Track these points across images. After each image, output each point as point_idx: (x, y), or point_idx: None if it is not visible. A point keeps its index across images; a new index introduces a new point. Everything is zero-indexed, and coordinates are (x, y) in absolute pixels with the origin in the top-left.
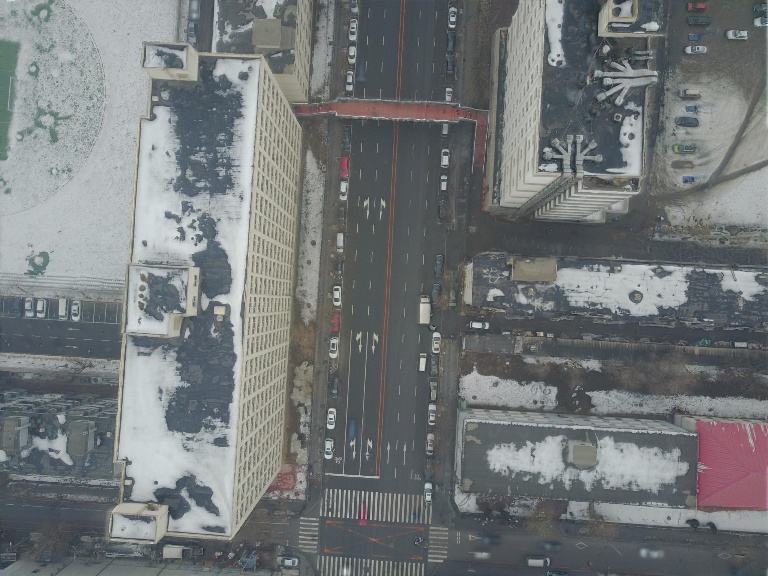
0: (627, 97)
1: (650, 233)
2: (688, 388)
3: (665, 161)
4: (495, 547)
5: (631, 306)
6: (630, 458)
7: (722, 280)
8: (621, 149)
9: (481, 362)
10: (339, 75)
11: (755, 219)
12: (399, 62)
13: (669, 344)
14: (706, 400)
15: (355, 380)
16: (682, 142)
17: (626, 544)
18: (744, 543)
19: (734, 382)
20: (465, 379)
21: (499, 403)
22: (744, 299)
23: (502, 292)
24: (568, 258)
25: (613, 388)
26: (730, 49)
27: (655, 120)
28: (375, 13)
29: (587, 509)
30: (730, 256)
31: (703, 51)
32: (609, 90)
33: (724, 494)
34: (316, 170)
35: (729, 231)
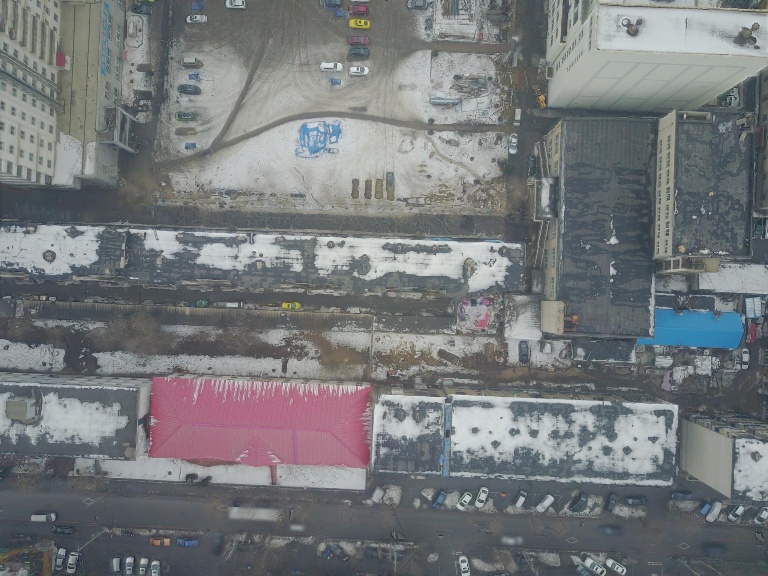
0: None
1: (153, 198)
2: (188, 348)
3: (169, 128)
4: (7, 504)
5: (45, 265)
6: (72, 413)
7: (145, 239)
8: None
9: None
10: None
11: (253, 183)
12: None
13: (169, 305)
14: (205, 359)
15: None
16: (185, 109)
17: (132, 499)
18: (241, 495)
19: None
20: None
21: (10, 365)
22: (165, 257)
23: None
24: None
25: (118, 349)
26: (231, 18)
27: (160, 88)
28: None
29: (93, 466)
30: (230, 220)
31: (201, 20)
32: None
33: (171, 446)
34: None
35: (229, 195)
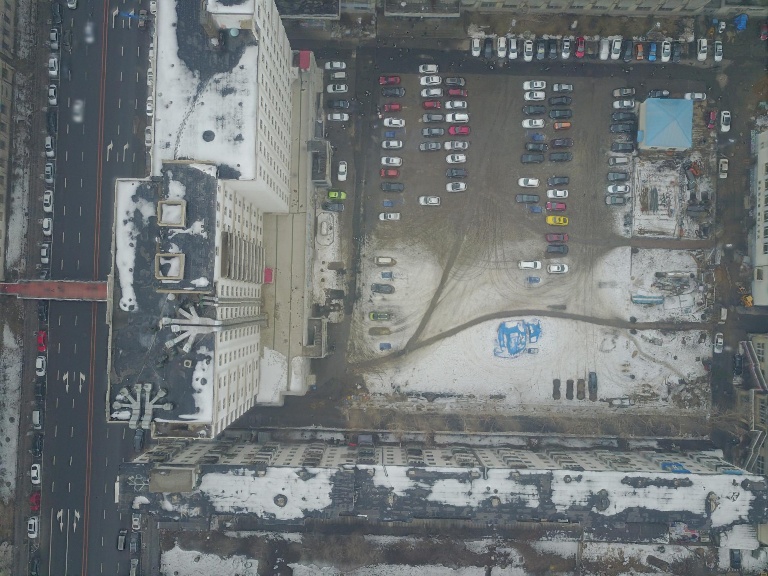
0: (199, 341)
1: (348, 402)
2: (388, 557)
3: (362, 328)
4: None
5: (276, 510)
6: None
7: (374, 476)
8: (194, 394)
9: (182, 537)
10: (35, 247)
11: (451, 385)
12: (97, 232)
13: None
14: (406, 568)
15: (57, 559)
16: (379, 309)
17: None
18: None
19: (433, 549)
20: (166, 555)
21: None
22: (395, 494)
23: (147, 499)
24: (262, 432)
25: None
26: (424, 214)
27: (352, 287)
28: (72, 182)
29: None
30: (427, 422)
31: (396, 218)
32: (177, 337)
33: None
34: (13, 345)
35: (426, 397)
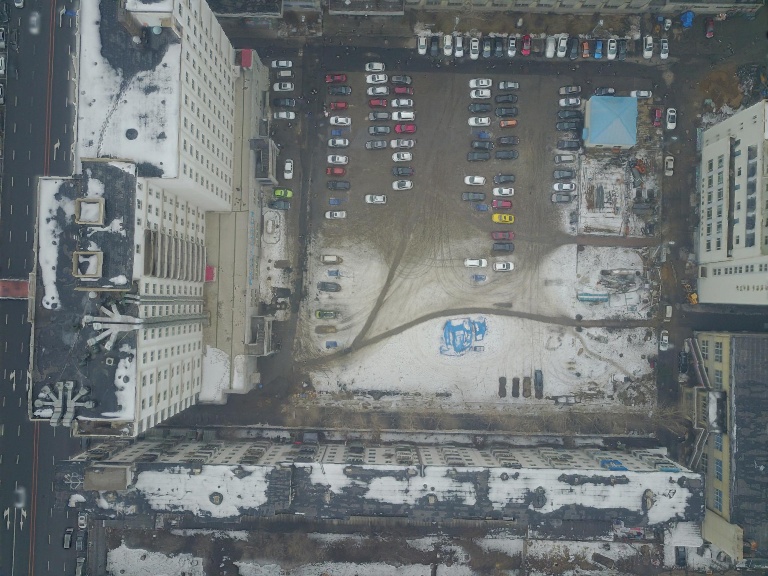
0: (122, 339)
1: (294, 400)
2: (334, 555)
3: (309, 326)
4: None
5: (212, 508)
6: None
7: (311, 473)
8: (116, 392)
9: (129, 535)
10: None
11: (397, 383)
12: None
13: None
14: (351, 566)
15: (4, 557)
16: (325, 307)
17: None
18: None
19: (379, 547)
20: (113, 553)
21: None
22: (332, 492)
23: (83, 497)
24: (207, 430)
25: None
26: (371, 212)
27: (298, 285)
28: (19, 181)
29: None
30: (374, 420)
31: (341, 216)
32: (99, 335)
33: None
34: None
35: (372, 395)
